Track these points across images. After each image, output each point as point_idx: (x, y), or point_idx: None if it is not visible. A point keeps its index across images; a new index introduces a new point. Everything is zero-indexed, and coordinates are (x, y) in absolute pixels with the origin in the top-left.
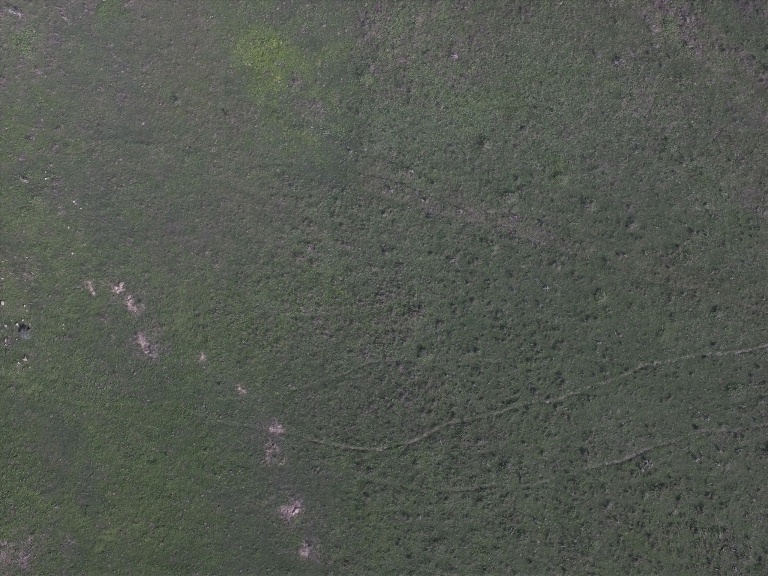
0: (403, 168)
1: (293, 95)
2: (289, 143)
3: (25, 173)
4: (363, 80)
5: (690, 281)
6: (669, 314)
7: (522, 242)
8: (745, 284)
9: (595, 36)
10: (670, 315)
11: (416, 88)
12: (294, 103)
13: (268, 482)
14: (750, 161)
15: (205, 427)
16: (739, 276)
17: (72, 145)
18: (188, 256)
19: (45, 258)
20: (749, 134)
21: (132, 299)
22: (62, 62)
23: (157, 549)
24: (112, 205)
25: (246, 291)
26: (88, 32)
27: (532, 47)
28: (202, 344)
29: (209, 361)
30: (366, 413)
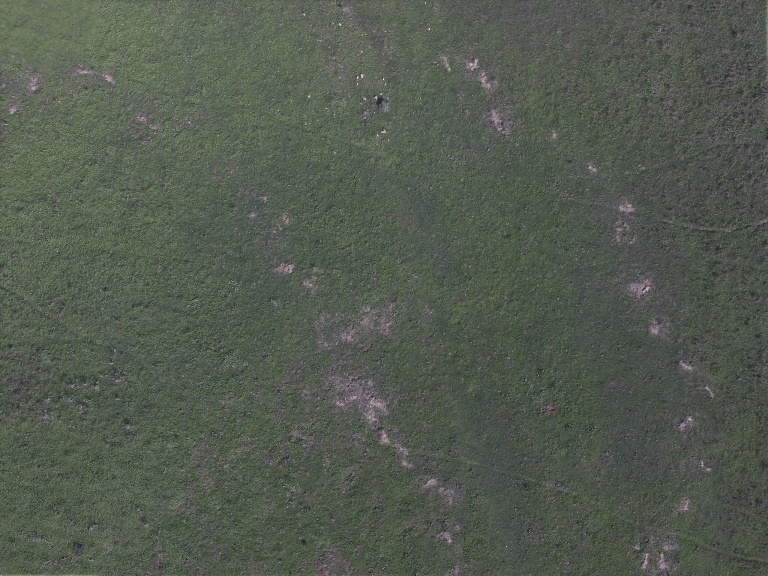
0: None
1: None
2: None
3: None
4: None
5: None
6: None
7: None
8: None
9: None
10: None
11: None
12: None
13: (618, 260)
14: None
15: (557, 204)
16: None
17: None
18: (540, 35)
19: (402, 33)
20: None
21: (486, 76)
22: None
23: (512, 322)
24: None
25: (596, 71)
26: None
27: None
28: (553, 123)
29: (560, 140)
30: (715, 194)
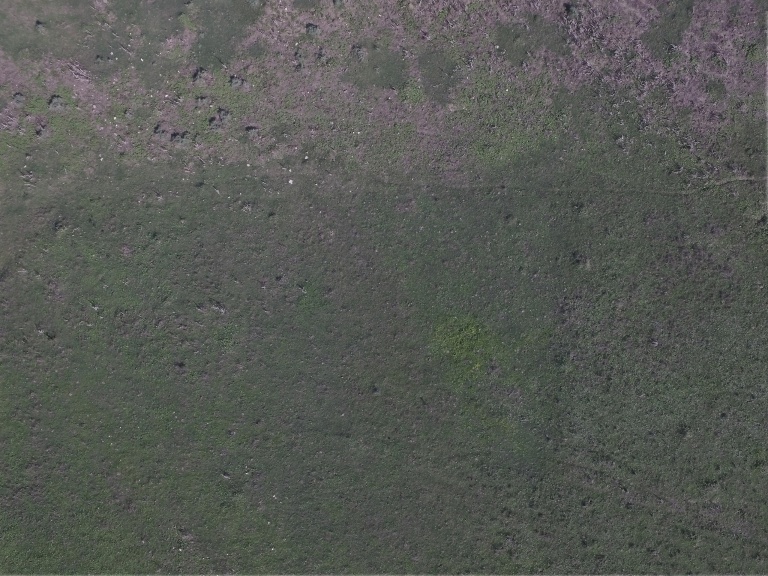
0: (603, 457)
1: (491, 382)
2: (487, 431)
3: (226, 468)
4: (563, 368)
5: None
6: None
7: (724, 533)
8: None
9: None
10: None
11: (616, 375)
12: (492, 390)
13: None
14: None
15: None
16: None
17: (272, 438)
18: (387, 549)
19: (245, 554)
20: None
21: None
22: (263, 355)
23: None
24: (312, 498)
25: None
26: (289, 324)
27: (732, 332)
28: None
29: None
30: None
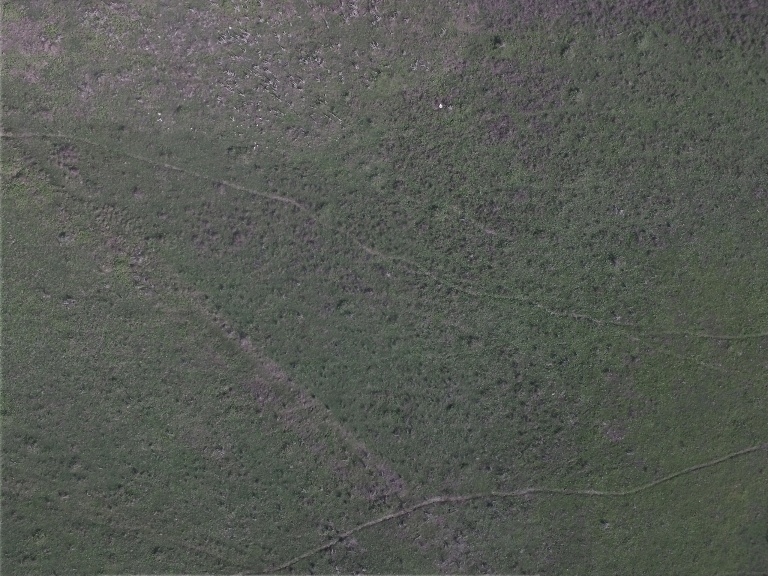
0: None
1: None
2: None
3: None
4: None
5: (133, 522)
6: (109, 555)
7: None
8: (189, 525)
9: (46, 275)
10: (109, 557)
11: None
12: None
13: None
14: (199, 401)
15: None
16: (182, 517)
17: None
18: None
19: None
20: (197, 375)
21: None
22: None
23: None
24: None
25: None
26: None
27: None
28: None
29: None
30: None
